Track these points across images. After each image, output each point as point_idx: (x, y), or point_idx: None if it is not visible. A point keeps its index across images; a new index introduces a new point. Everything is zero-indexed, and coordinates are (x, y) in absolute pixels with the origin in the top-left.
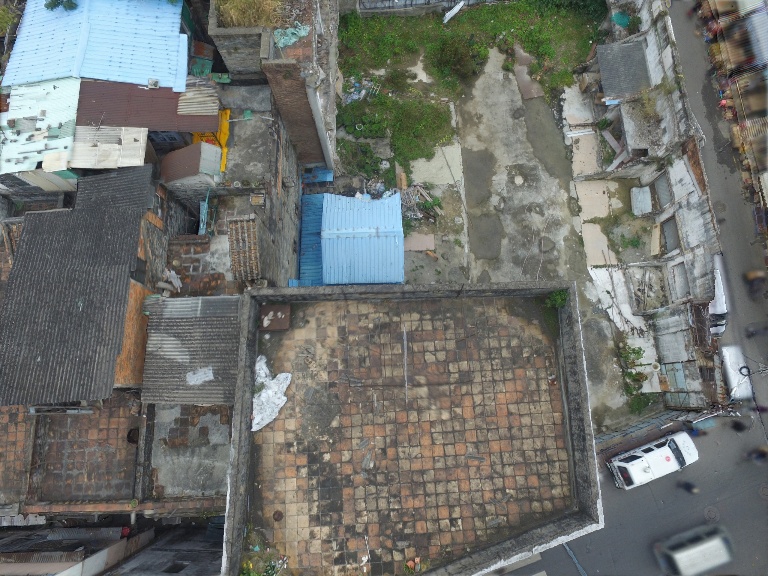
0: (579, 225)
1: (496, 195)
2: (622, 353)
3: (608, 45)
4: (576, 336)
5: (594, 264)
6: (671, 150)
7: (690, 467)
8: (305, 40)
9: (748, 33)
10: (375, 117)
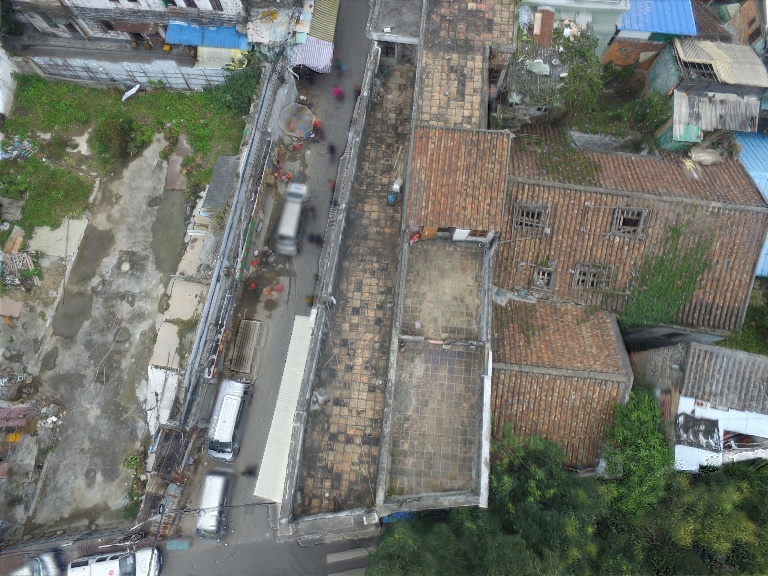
0: (160, 323)
1: (99, 277)
2: None
3: (227, 157)
4: None
5: (156, 364)
6: None
7: None
8: None
9: None
10: (16, 179)
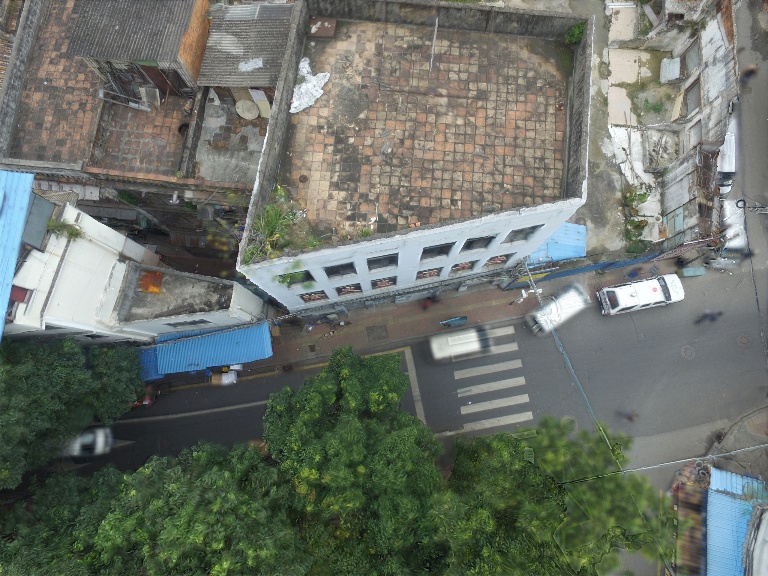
0: (606, 87)
1: None
2: None
3: None
4: (587, 57)
5: (615, 123)
6: (706, 11)
7: (675, 310)
8: None
9: None
10: None
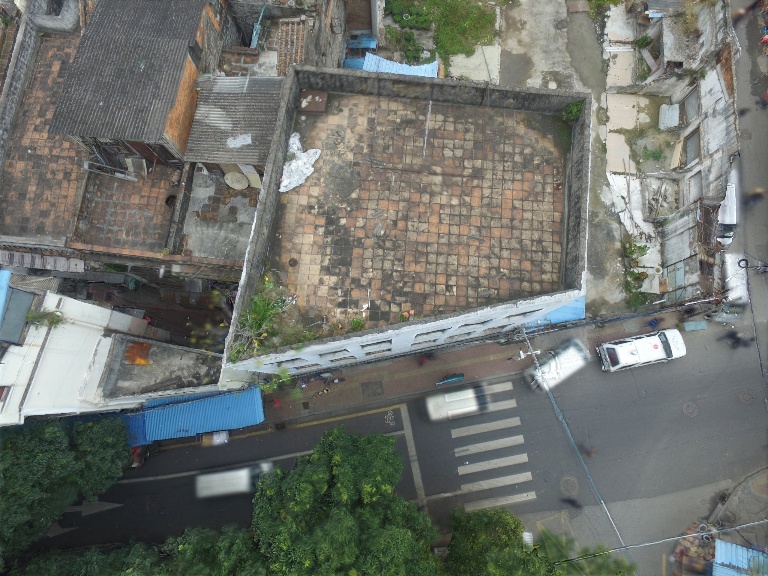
0: (604, 133)
1: None
2: None
3: None
4: (586, 138)
5: (613, 170)
6: (706, 61)
7: (676, 365)
8: None
9: None
10: (423, 10)
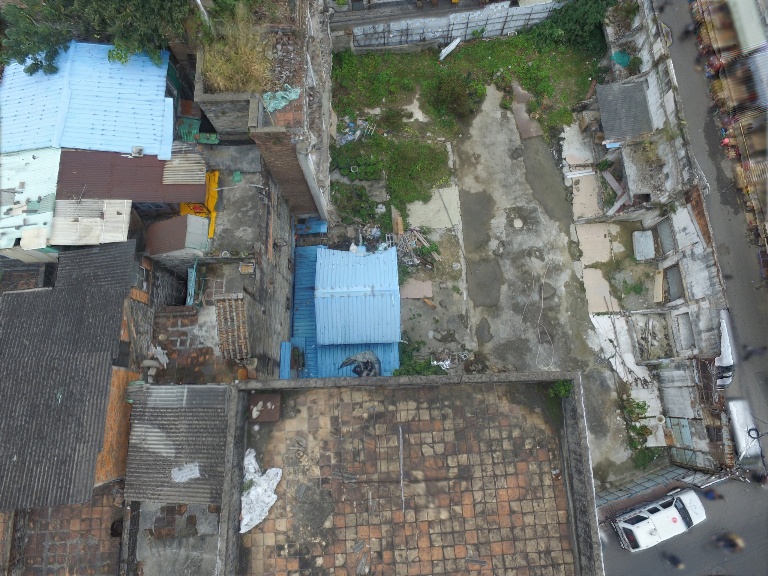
0: (580, 270)
1: (495, 239)
2: (626, 406)
3: (608, 85)
4: (581, 433)
5: (596, 311)
6: (674, 197)
7: (697, 525)
8: (295, 104)
9: (751, 73)
10: (370, 159)
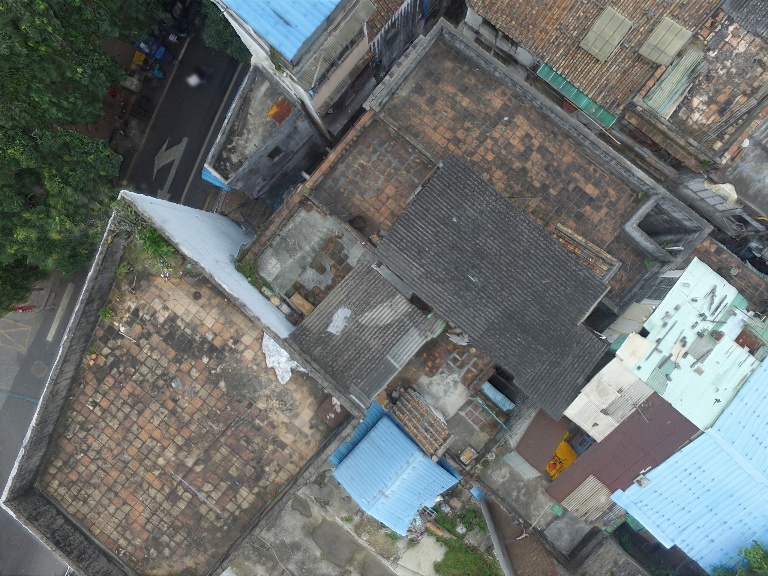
0: None
1: None
2: None
3: None
4: None
5: None
6: None
7: None
8: None
9: None
10: None
